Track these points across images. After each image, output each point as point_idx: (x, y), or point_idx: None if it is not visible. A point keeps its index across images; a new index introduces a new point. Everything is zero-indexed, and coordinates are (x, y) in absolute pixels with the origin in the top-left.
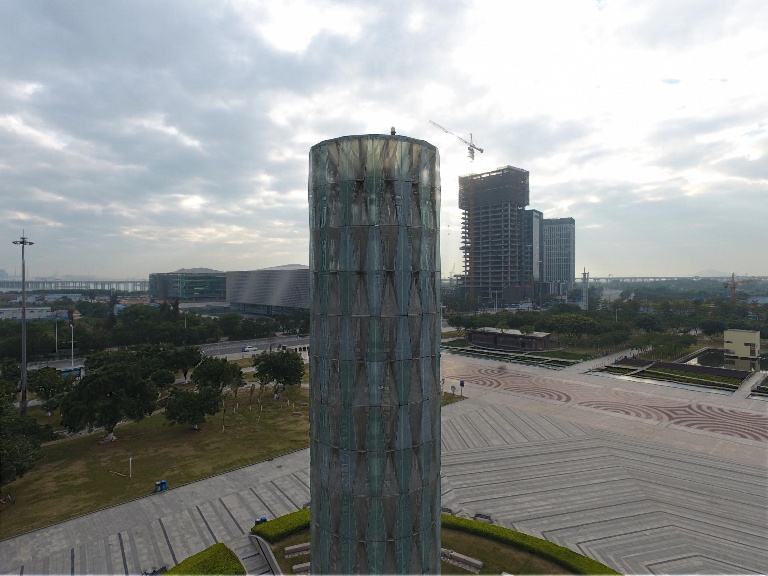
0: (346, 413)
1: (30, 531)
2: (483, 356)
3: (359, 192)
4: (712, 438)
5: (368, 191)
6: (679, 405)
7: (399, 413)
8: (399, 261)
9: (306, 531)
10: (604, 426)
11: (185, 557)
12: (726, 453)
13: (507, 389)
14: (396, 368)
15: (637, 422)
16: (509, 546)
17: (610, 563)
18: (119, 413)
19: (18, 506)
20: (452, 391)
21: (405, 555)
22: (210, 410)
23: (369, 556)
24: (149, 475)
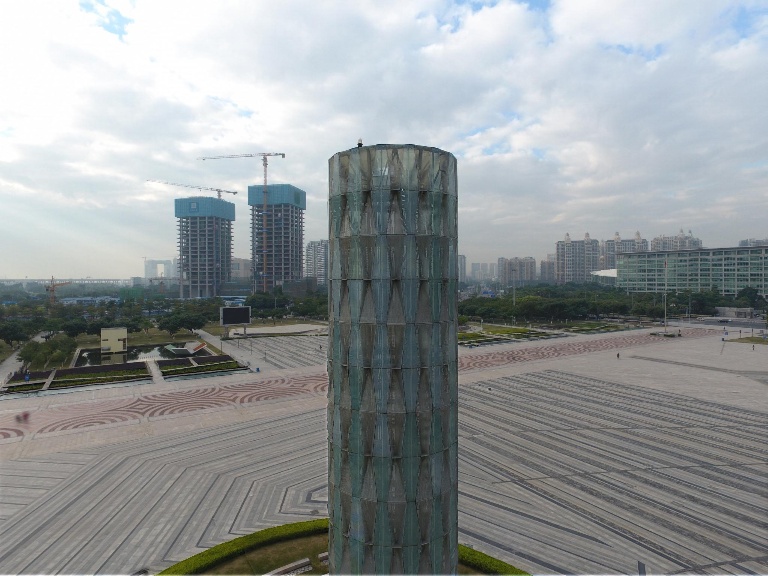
0: None
1: None
2: None
3: None
4: (188, 417)
5: None
6: (132, 401)
7: None
8: None
9: None
10: (100, 441)
11: None
12: (210, 423)
13: None
14: None
15: (122, 426)
16: (221, 565)
17: (264, 527)
18: None
19: None
20: None
21: None
22: None
23: None
24: None
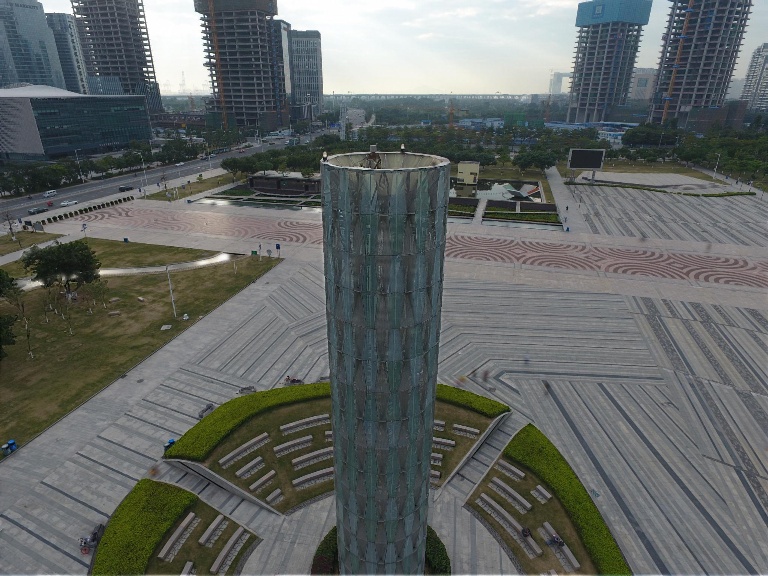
0: (392, 397)
1: None
2: (273, 205)
3: (407, 223)
4: (472, 265)
5: (417, 222)
6: None
7: (427, 384)
8: (433, 275)
9: (227, 439)
10: None
11: (111, 506)
12: (483, 276)
13: (314, 243)
14: (428, 356)
15: None
16: None
17: (447, 382)
18: None
19: None
20: (268, 254)
21: (424, 466)
22: (8, 341)
23: (407, 478)
24: None
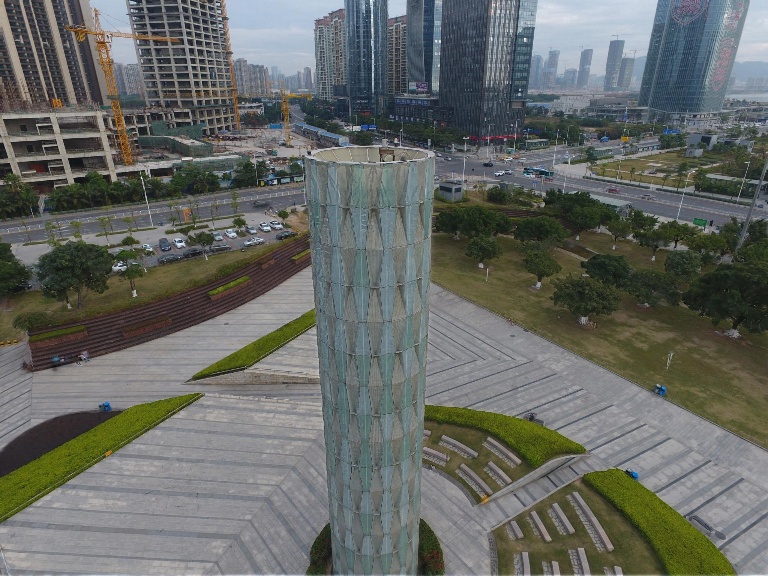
0: None
1: (567, 349)
2: None
3: None
4: None
5: None
6: None
7: None
8: None
9: (612, 509)
10: None
11: (565, 433)
12: None
13: None
14: None
15: None
16: None
17: None
18: (726, 313)
19: (592, 333)
20: None
21: None
22: None
23: None
24: (680, 379)
